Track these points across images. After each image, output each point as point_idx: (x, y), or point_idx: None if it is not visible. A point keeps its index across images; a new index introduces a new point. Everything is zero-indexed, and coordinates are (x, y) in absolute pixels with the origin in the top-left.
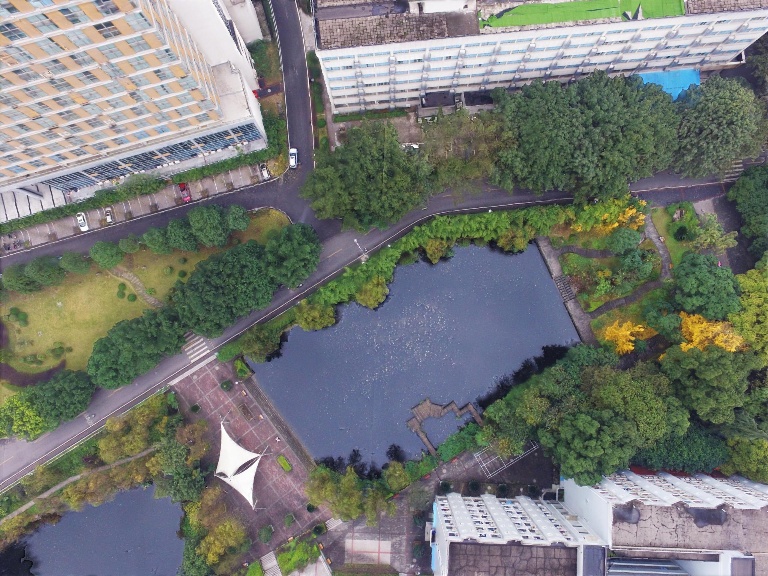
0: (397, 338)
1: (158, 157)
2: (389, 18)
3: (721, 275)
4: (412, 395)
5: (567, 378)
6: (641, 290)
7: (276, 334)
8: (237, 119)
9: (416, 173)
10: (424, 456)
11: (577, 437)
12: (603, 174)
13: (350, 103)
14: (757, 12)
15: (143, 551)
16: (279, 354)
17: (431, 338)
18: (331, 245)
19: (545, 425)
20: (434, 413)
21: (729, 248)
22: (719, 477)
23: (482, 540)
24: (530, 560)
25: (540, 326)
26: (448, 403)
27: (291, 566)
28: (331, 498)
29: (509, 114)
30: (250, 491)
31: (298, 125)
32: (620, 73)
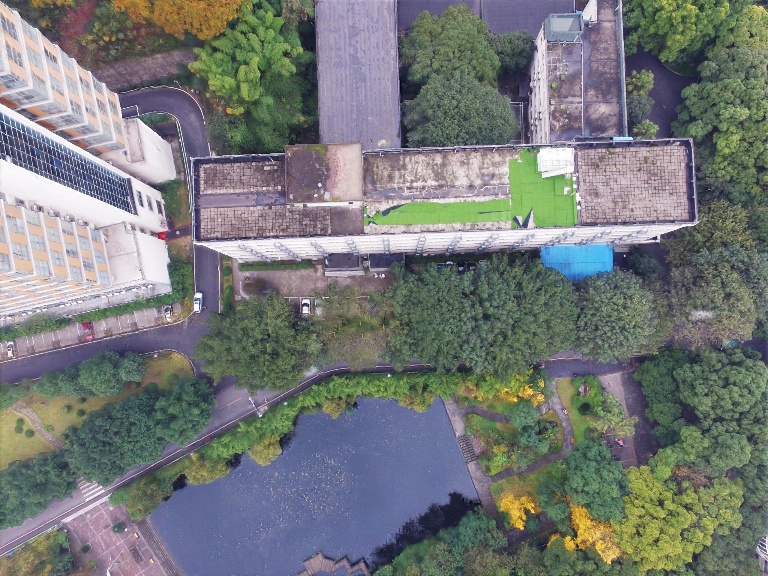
0: (294, 488)
1: None
2: (272, 210)
3: (607, 478)
4: (305, 547)
5: (450, 560)
6: (541, 461)
7: (169, 483)
8: (128, 281)
9: (305, 349)
10: None
11: None
12: (494, 365)
13: (254, 257)
14: (652, 226)
15: None
16: (184, 484)
17: (328, 490)
18: (231, 393)
19: None
20: (325, 568)
21: (634, 425)
22: None
23: None
24: None
25: (439, 485)
26: (341, 558)
27: None
28: None
29: (399, 300)
30: None
31: (205, 269)
32: (530, 245)
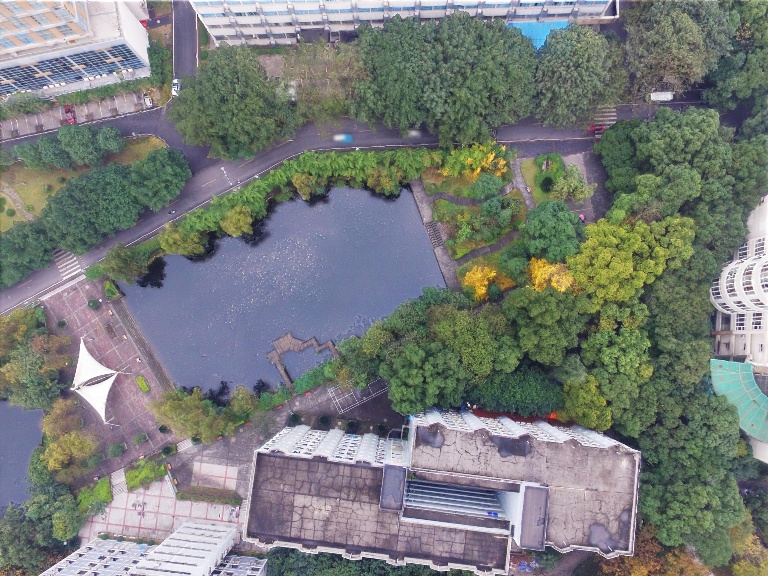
0: (265, 271)
1: (40, 76)
2: None
3: (562, 218)
4: (275, 328)
5: (412, 314)
6: (505, 239)
7: (143, 256)
8: (107, 38)
9: (274, 100)
10: (279, 387)
11: (406, 367)
12: (454, 112)
13: (229, 35)
14: None
15: (5, 461)
16: (160, 284)
17: (298, 274)
18: (206, 175)
19: (385, 358)
20: (294, 347)
21: (596, 203)
22: (559, 426)
23: (289, 453)
24: (336, 478)
25: (407, 270)
26: (309, 338)
27: (137, 482)
28: (170, 413)
29: (364, 46)
30: (103, 405)
31: (184, 57)
32: None
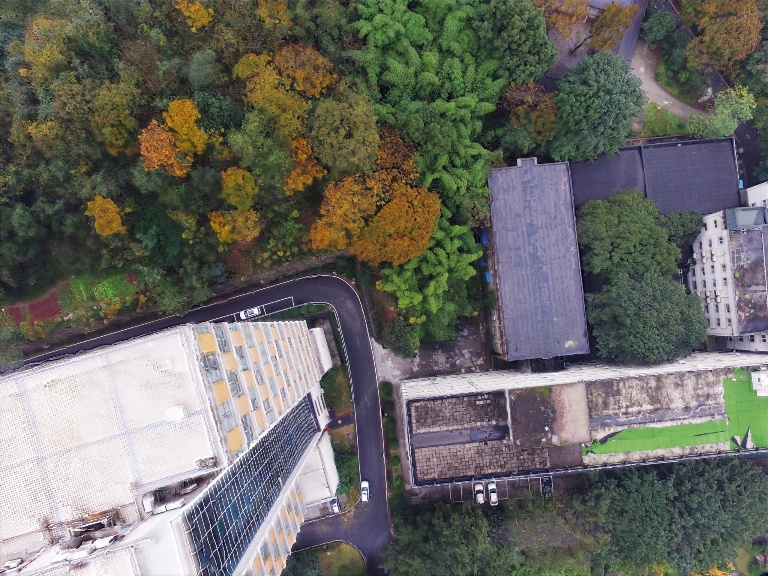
0: None
1: None
2: (488, 445)
3: None
4: None
5: None
6: None
7: None
8: (317, 501)
9: (504, 559)
10: None
11: None
12: None
13: None
14: None
15: None
16: None
17: None
18: None
19: None
20: None
21: None
22: None
23: None
24: None
25: None
26: None
27: None
28: None
29: (604, 510)
30: None
31: (370, 456)
32: None
